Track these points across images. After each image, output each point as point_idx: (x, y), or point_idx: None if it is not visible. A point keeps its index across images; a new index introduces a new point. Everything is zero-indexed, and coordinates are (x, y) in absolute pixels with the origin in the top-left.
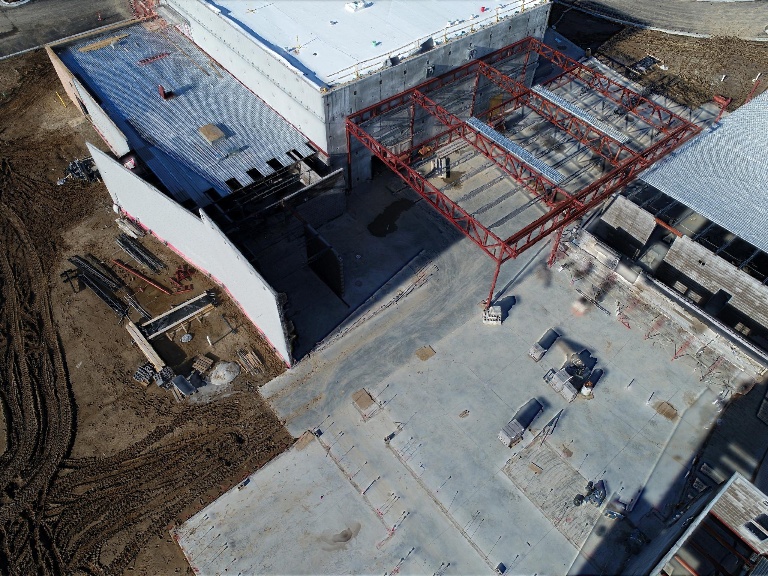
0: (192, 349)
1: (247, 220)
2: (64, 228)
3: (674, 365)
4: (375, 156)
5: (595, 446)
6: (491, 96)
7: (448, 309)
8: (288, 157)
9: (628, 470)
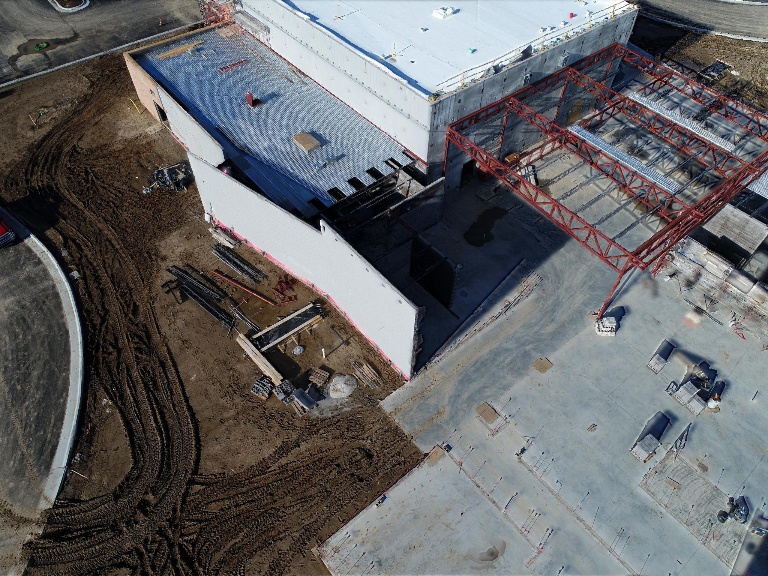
0: (305, 361)
1: (356, 230)
2: (157, 238)
3: None
4: (466, 164)
5: (730, 461)
6: None
7: (558, 320)
8: (387, 166)
9: (767, 485)
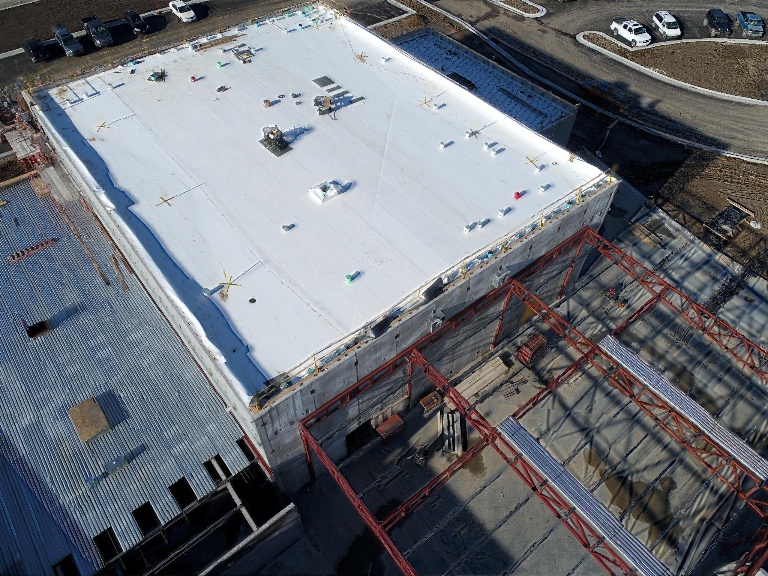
0: None
1: None
2: None
3: None
4: (352, 433)
5: None
6: None
7: None
8: (206, 475)
9: None
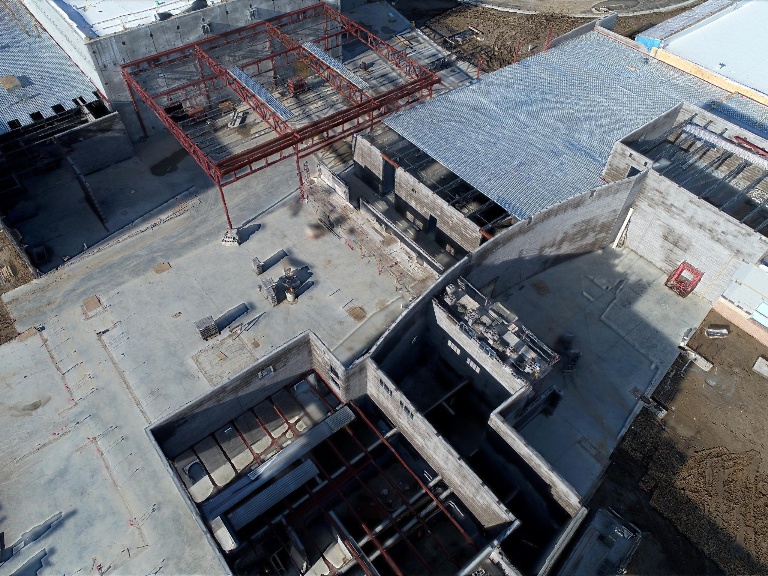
0: None
1: (15, 153)
2: None
3: (380, 278)
4: None
5: (282, 340)
6: None
7: (196, 234)
8: (72, 103)
9: None
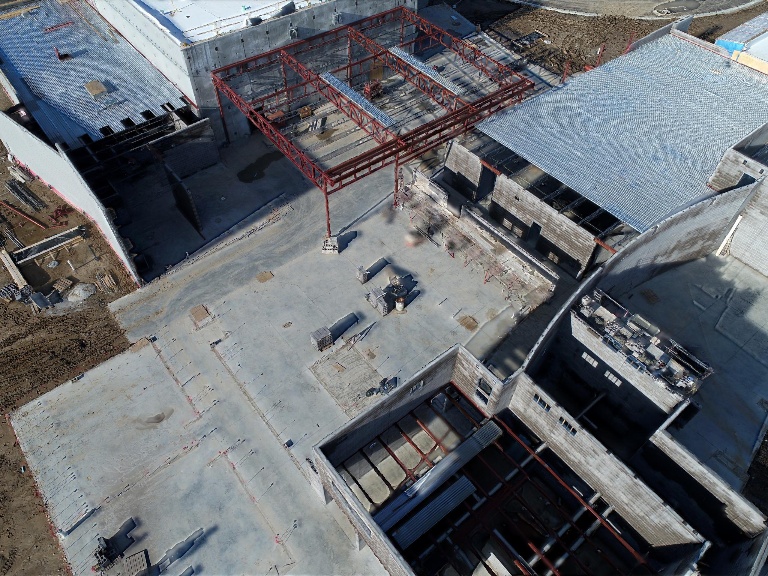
0: (56, 273)
1: (112, 160)
2: None
3: (486, 287)
4: (250, 112)
5: (397, 351)
6: (367, 61)
7: (294, 241)
8: (161, 109)
9: None
